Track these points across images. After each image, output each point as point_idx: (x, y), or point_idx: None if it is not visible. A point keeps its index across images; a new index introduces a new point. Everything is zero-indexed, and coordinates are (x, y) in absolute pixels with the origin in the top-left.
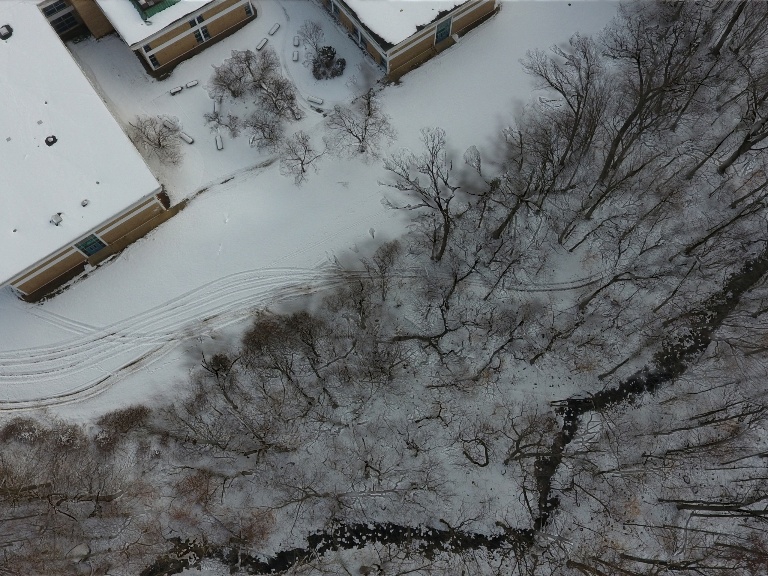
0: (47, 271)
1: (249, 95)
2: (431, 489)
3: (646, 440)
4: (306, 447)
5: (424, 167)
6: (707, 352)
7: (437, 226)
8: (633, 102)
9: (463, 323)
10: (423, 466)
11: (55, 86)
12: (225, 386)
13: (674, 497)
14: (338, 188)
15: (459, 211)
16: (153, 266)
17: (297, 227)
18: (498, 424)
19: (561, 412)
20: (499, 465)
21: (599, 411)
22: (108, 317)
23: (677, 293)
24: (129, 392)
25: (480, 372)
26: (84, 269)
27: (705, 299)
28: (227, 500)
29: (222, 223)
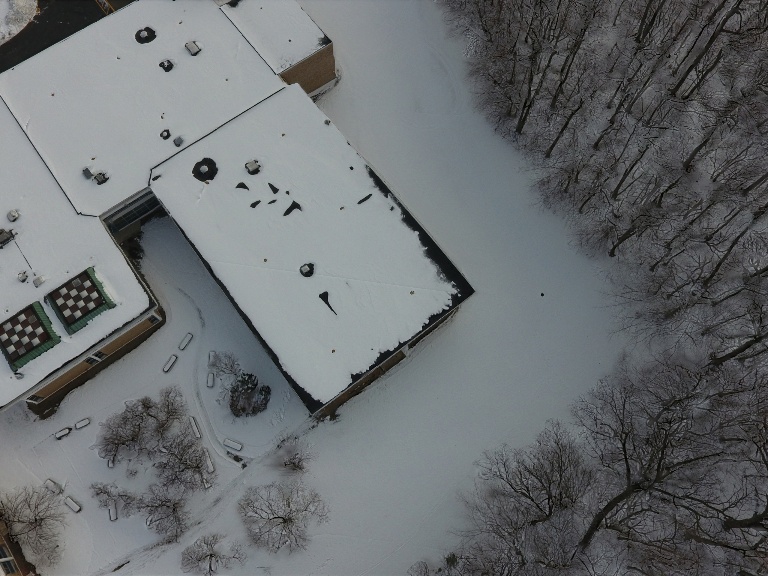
0: None
1: (147, 457)
2: None
3: None
4: None
5: None
6: None
7: None
8: None
9: None
10: None
11: None
12: None
13: None
14: (258, 575)
15: None
16: None
17: None
18: None
19: None
20: None
21: None
22: None
23: None
24: None
25: None
26: None
27: None
28: None
29: None
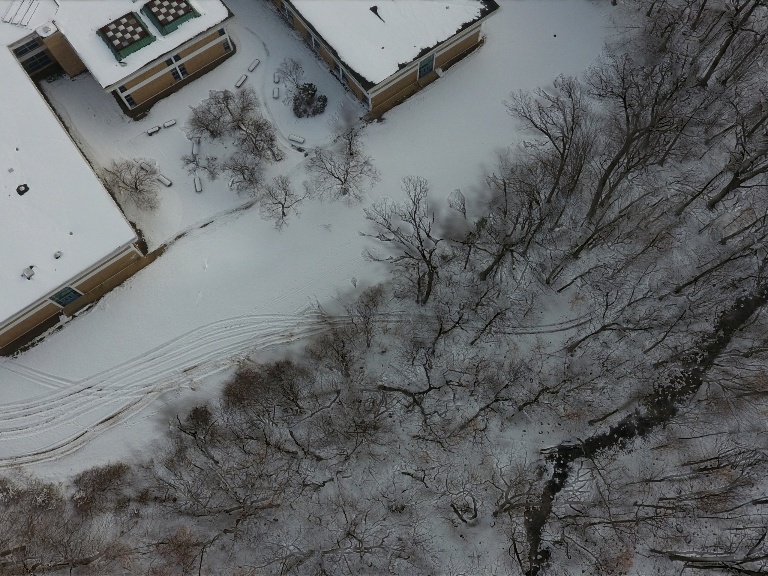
0: (20, 324)
1: (228, 136)
2: (418, 544)
3: (637, 488)
4: (290, 502)
5: (406, 215)
6: (698, 394)
7: (421, 274)
8: (620, 141)
9: (447, 382)
10: (410, 520)
11: (27, 132)
12: (206, 440)
13: (667, 548)
14: (320, 231)
15: (444, 252)
16: (130, 316)
17: (279, 272)
18: (486, 474)
19: (551, 459)
20: (488, 517)
21: (589, 457)
22: (84, 370)
23: None
24: (107, 448)
25: (467, 423)
26: (59, 320)
27: (696, 338)
28: (208, 560)
29: (201, 269)
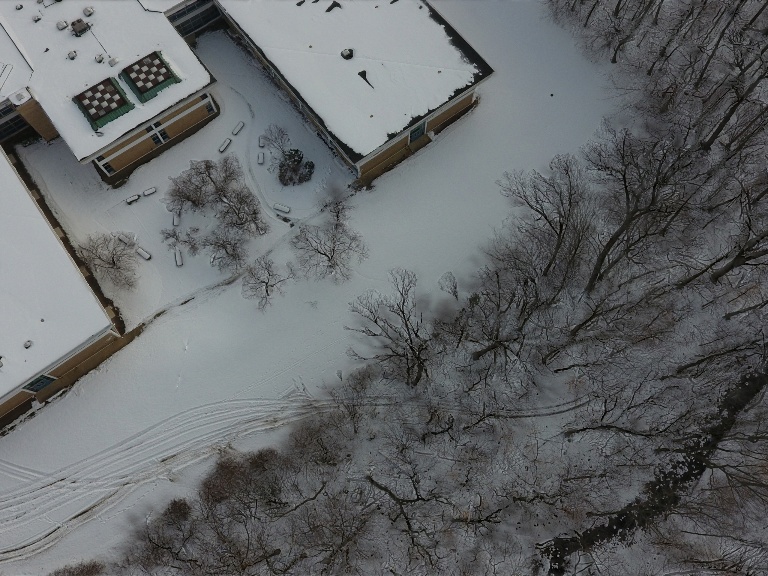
0: None
1: (209, 208)
2: None
3: None
4: None
5: (394, 307)
6: (702, 482)
7: (410, 365)
8: (619, 219)
9: (436, 498)
10: None
11: None
12: (184, 535)
13: None
14: (306, 308)
15: (436, 330)
16: (106, 402)
17: (262, 353)
18: (479, 572)
19: (547, 553)
20: None
21: (587, 551)
22: (57, 461)
23: (669, 417)
24: (80, 545)
25: (458, 521)
26: (31, 406)
27: (699, 420)
28: None
29: (181, 351)
